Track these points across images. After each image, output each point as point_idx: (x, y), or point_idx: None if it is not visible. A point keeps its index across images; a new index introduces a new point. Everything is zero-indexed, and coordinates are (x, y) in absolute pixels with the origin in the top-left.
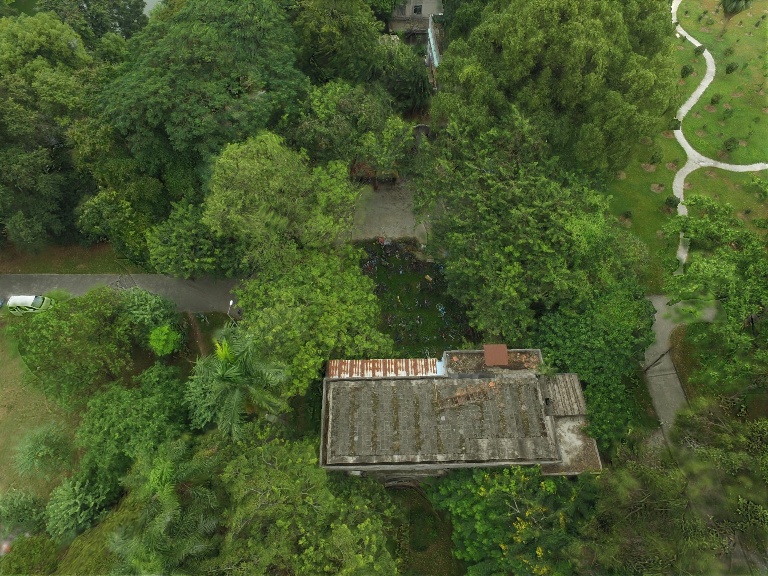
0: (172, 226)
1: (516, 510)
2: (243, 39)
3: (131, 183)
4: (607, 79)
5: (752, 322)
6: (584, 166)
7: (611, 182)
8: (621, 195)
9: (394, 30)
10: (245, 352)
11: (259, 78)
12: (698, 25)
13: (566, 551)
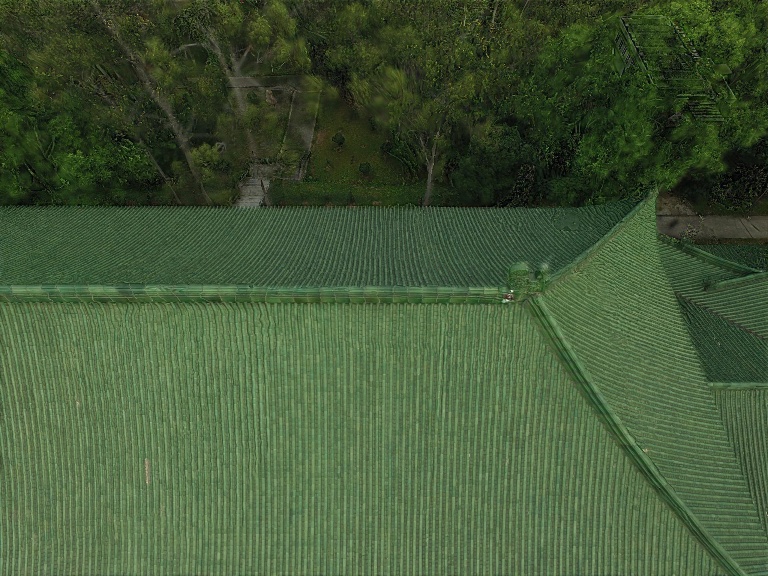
0: None
1: None
2: None
3: None
4: None
5: None
6: None
7: None
8: None
9: None
10: None
11: None
12: None
13: None
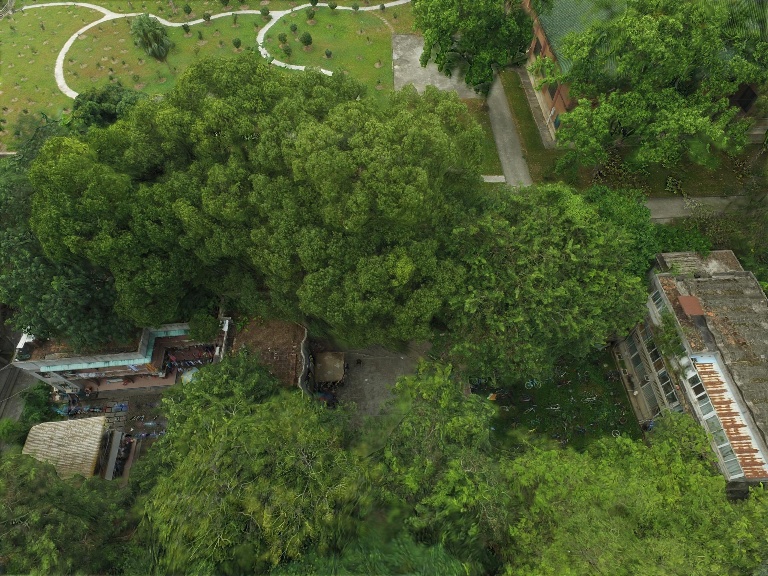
0: None
1: None
2: None
3: None
4: None
5: (610, 132)
6: None
7: None
8: None
9: None
10: None
11: None
12: None
13: None
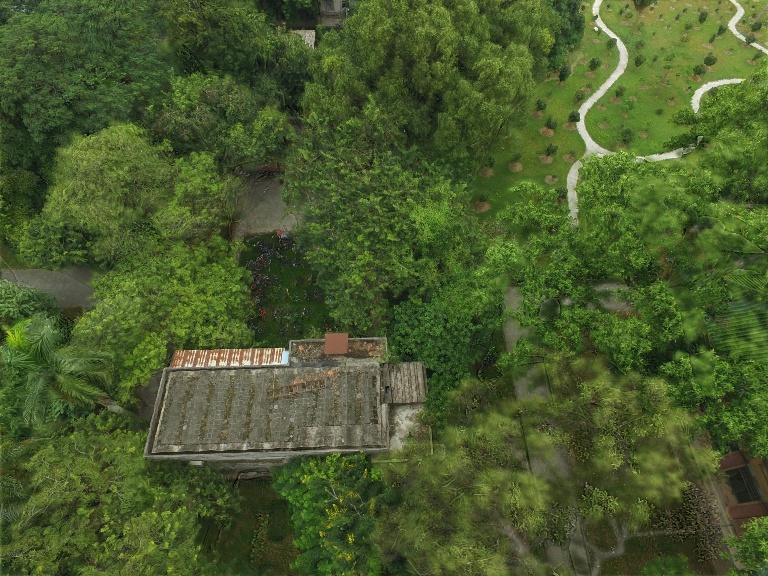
0: (42, 219)
1: (335, 497)
2: (96, 30)
3: (3, 176)
4: (459, 68)
5: None
6: (447, 156)
7: (506, 174)
8: None
9: (323, 25)
10: (40, 340)
11: (117, 69)
12: (619, 19)
13: (371, 536)
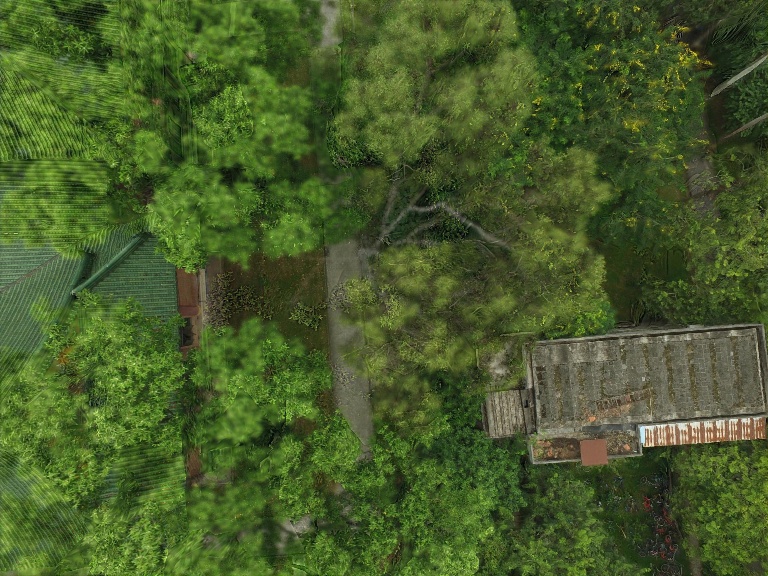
0: None
1: None
2: None
3: None
4: None
5: None
6: None
7: None
8: None
9: None
10: None
11: None
12: None
13: None
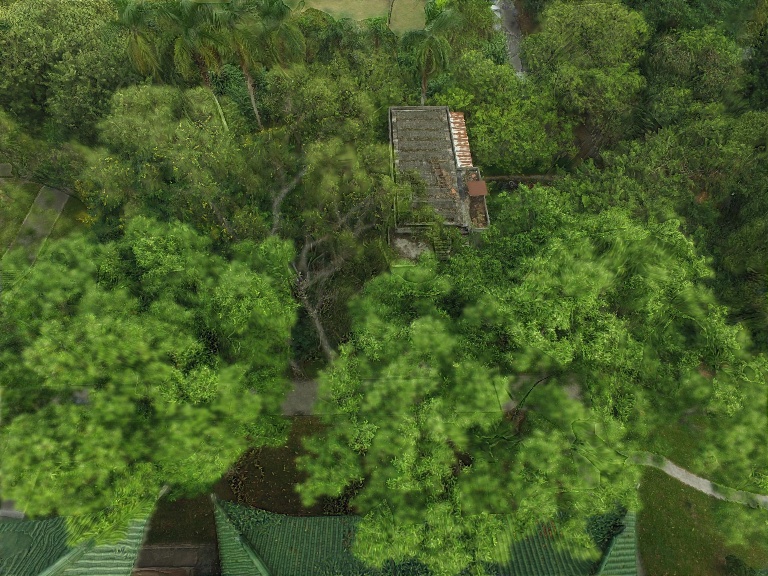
0: None
1: None
2: None
3: None
4: None
5: None
6: None
7: None
8: (763, 418)
9: None
10: None
11: None
12: None
13: None
